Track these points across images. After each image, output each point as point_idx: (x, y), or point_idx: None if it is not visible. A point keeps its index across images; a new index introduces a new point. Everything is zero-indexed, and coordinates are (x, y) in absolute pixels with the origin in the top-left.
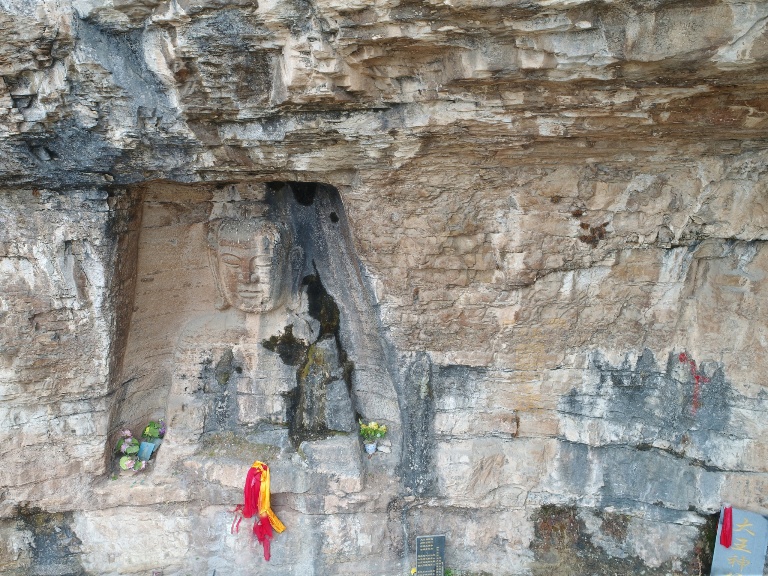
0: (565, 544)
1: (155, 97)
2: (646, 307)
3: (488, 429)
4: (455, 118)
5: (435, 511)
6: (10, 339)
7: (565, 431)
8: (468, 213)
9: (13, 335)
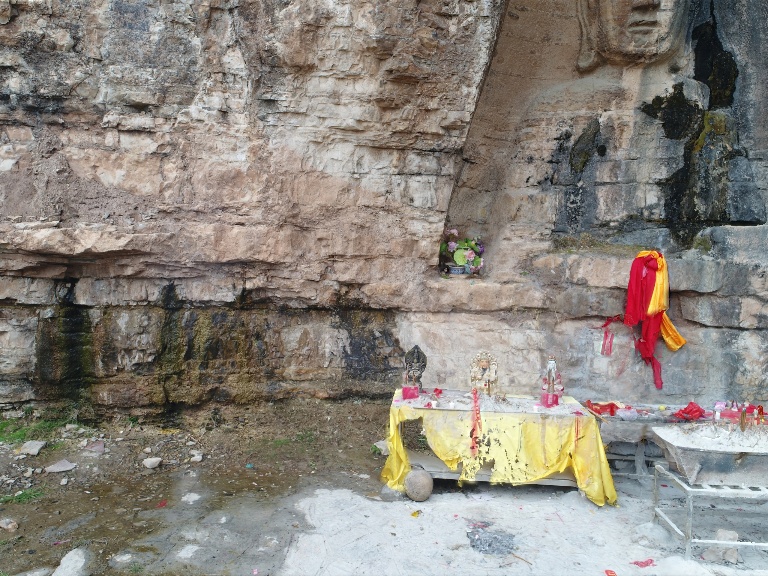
0: None
1: None
2: None
3: None
4: None
5: None
6: (392, 24)
7: None
8: None
9: (395, 20)
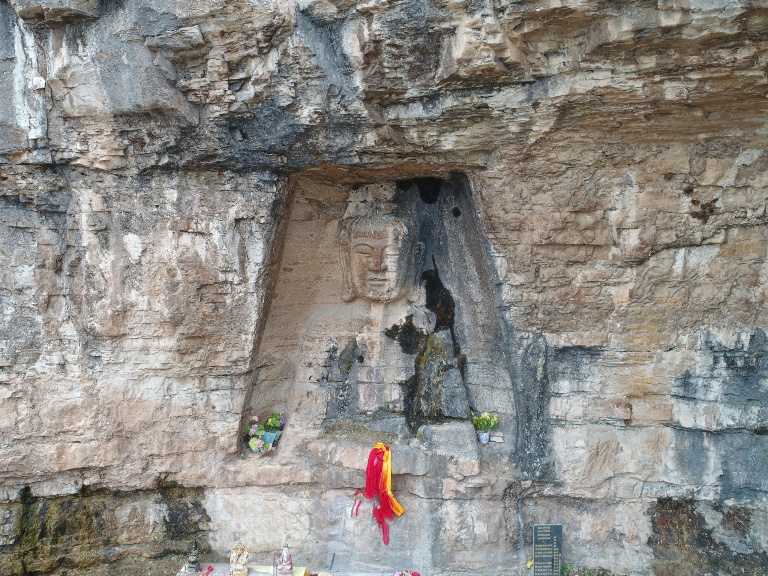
0: (685, 540)
1: (342, 78)
2: (755, 286)
3: (602, 415)
4: (593, 86)
5: (549, 502)
6: (179, 306)
7: (679, 417)
8: (589, 190)
9: (182, 303)
